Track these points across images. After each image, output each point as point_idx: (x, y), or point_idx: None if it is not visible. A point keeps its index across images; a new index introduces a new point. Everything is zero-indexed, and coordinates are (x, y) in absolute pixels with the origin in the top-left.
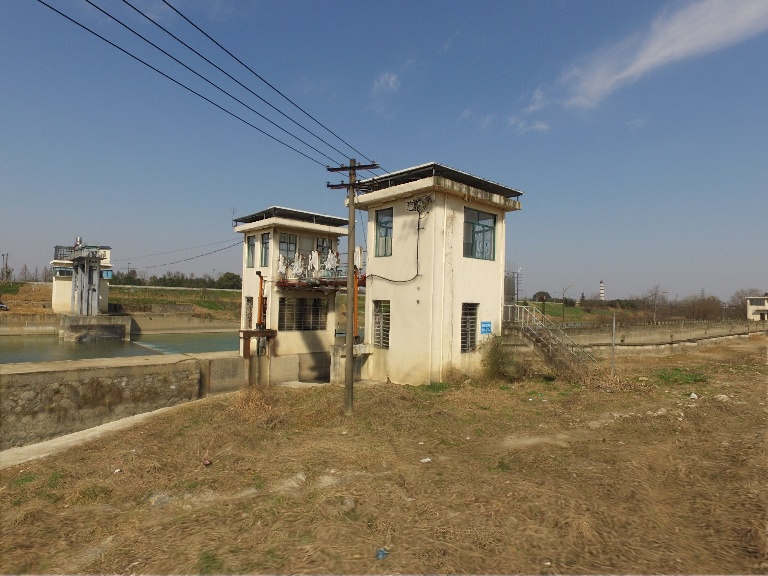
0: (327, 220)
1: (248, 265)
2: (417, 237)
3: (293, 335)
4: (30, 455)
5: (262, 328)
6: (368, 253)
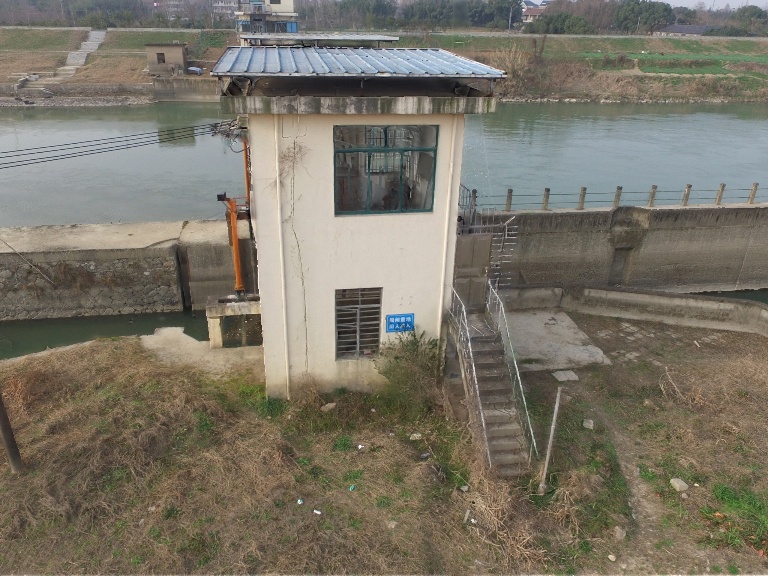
0: None
1: None
2: None
3: None
4: None
5: None
6: None
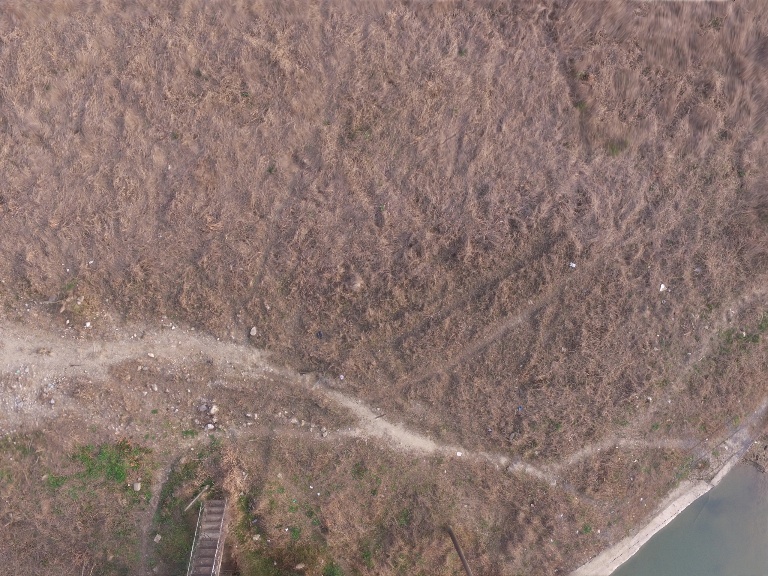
0: None
1: None
2: None
3: None
4: (584, 573)
5: None
6: None
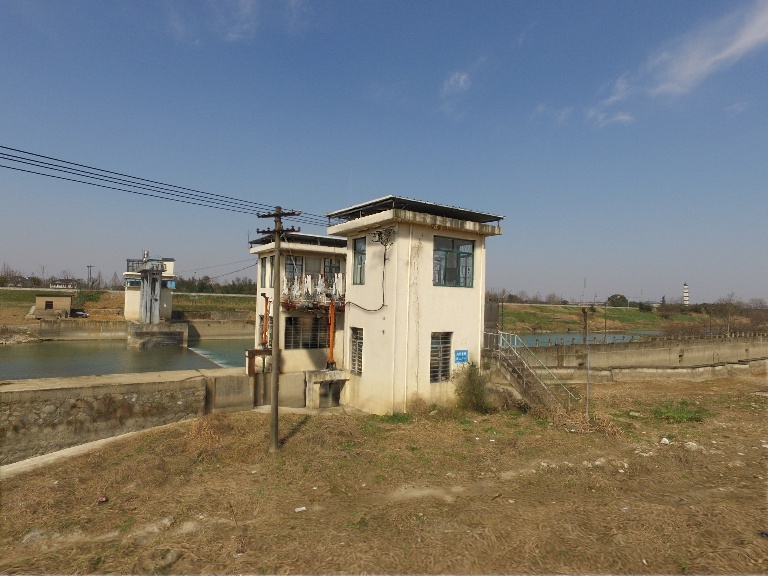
0: (333, 241)
1: (262, 285)
2: (384, 267)
3: (299, 353)
4: None
5: (267, 347)
6: (347, 280)
